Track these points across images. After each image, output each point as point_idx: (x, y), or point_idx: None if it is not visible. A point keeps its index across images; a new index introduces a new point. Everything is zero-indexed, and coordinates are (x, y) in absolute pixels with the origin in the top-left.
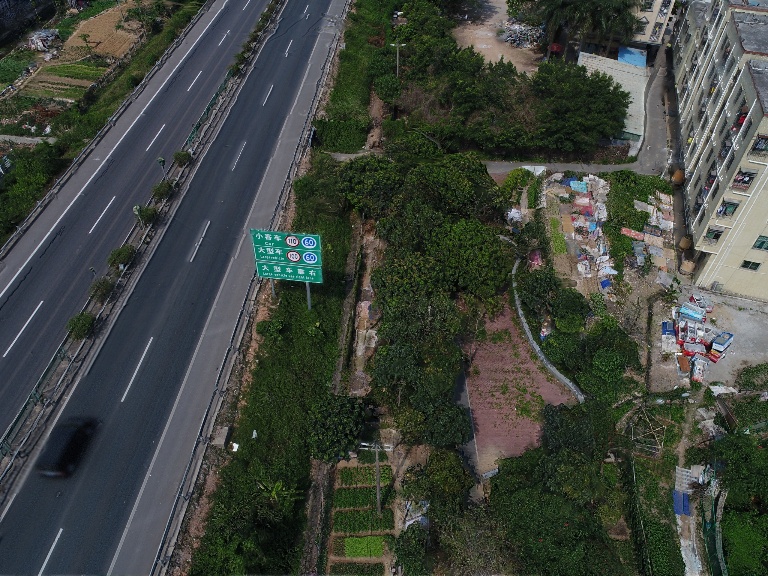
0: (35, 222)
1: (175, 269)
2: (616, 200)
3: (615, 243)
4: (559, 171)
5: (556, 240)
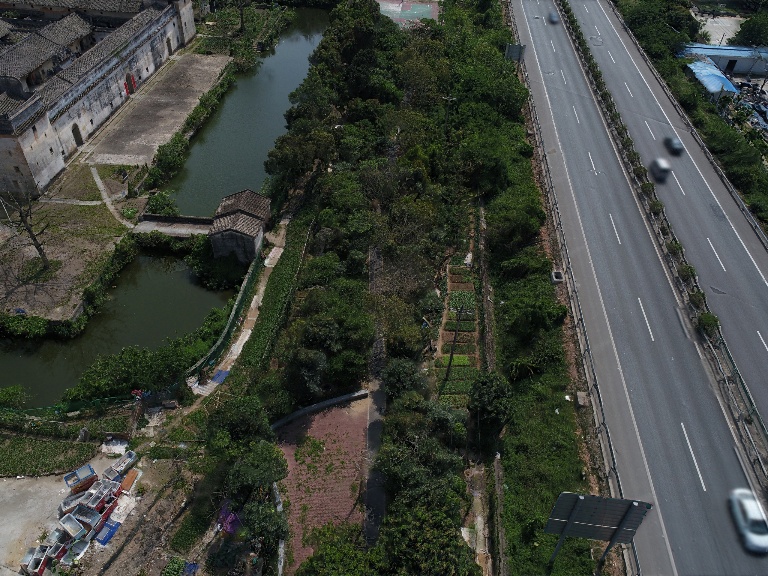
0: None
1: None
2: None
3: None
4: None
5: None
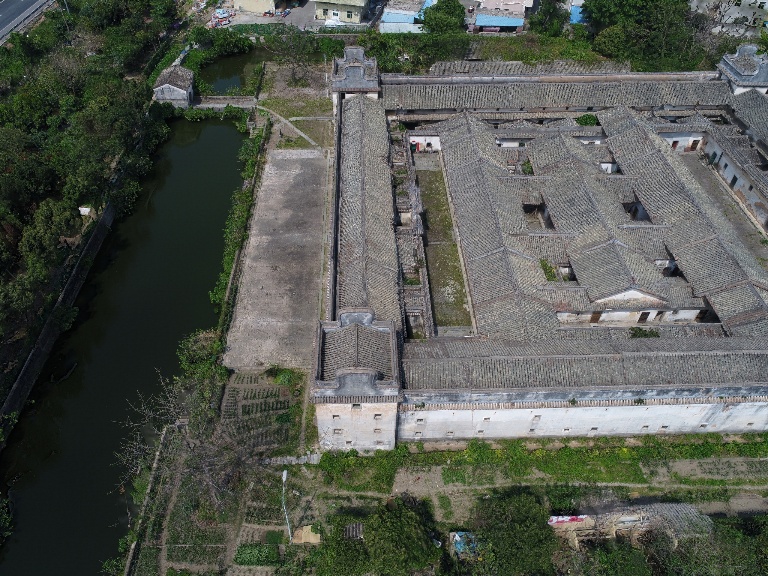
0: None
1: (15, 2)
2: None
3: None
4: None
5: (189, 1)
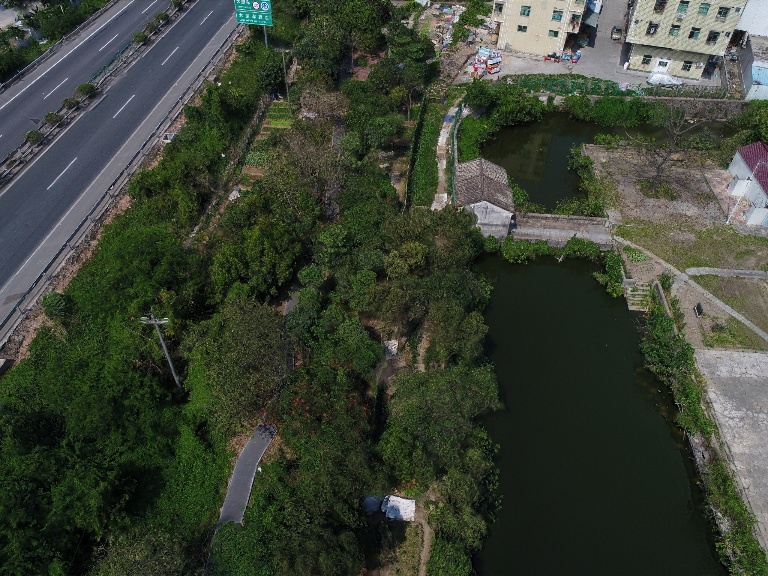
0: (110, 9)
1: (191, 26)
2: (466, 14)
3: (456, 30)
4: (438, 3)
5: (423, 31)
